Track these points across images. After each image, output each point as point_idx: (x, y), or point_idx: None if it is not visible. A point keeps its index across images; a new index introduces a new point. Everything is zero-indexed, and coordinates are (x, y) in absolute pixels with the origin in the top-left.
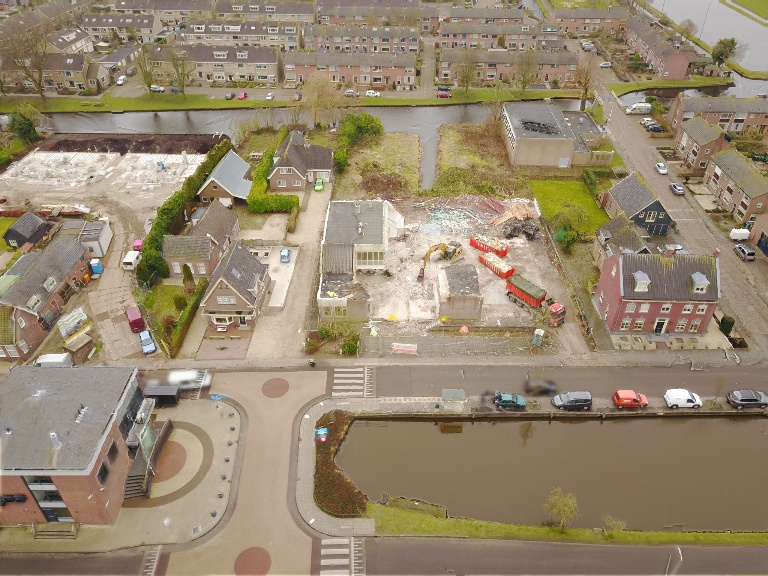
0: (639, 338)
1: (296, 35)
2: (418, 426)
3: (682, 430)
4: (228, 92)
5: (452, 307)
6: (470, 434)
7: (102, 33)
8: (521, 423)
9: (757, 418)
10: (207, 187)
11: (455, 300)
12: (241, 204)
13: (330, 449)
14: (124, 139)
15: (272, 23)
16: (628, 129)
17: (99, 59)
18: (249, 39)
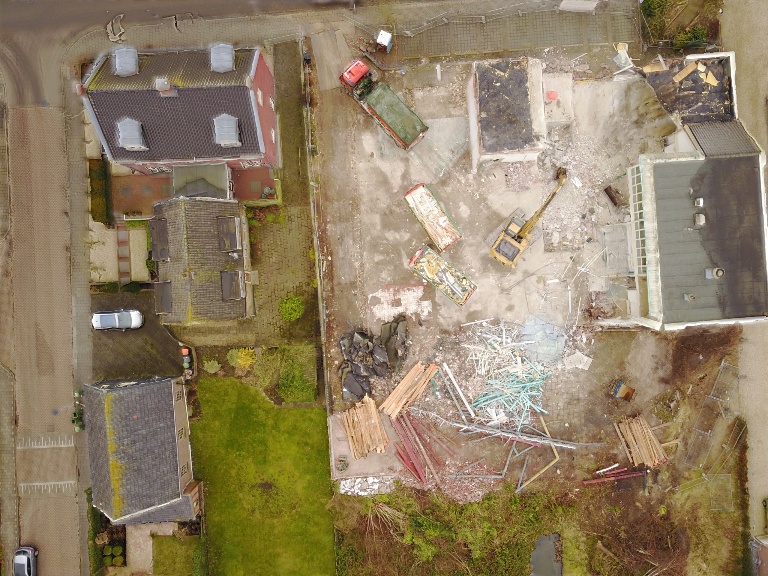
0: None
1: None
2: None
3: None
4: None
5: None
6: None
7: None
8: None
9: None
10: None
11: None
12: None
13: None
14: None
15: None
16: None
17: None
18: None
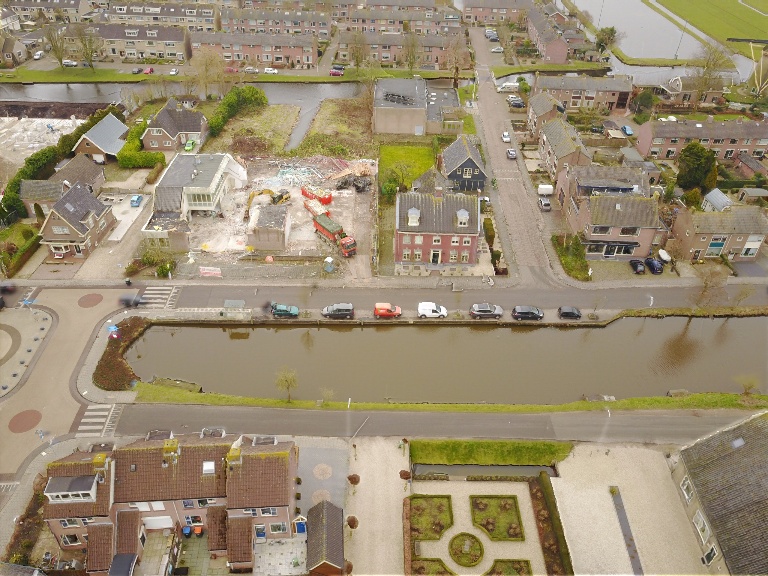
0: (418, 267)
1: (213, 17)
2: (207, 331)
3: (432, 337)
4: (136, 67)
5: (259, 239)
6: (252, 339)
7: (31, 13)
8: (301, 332)
9: (494, 327)
10: (80, 144)
11: (260, 232)
12: (114, 161)
13: (120, 344)
14: (23, 105)
15: (190, 6)
16: (494, 105)
17: (21, 36)
18: (169, 20)
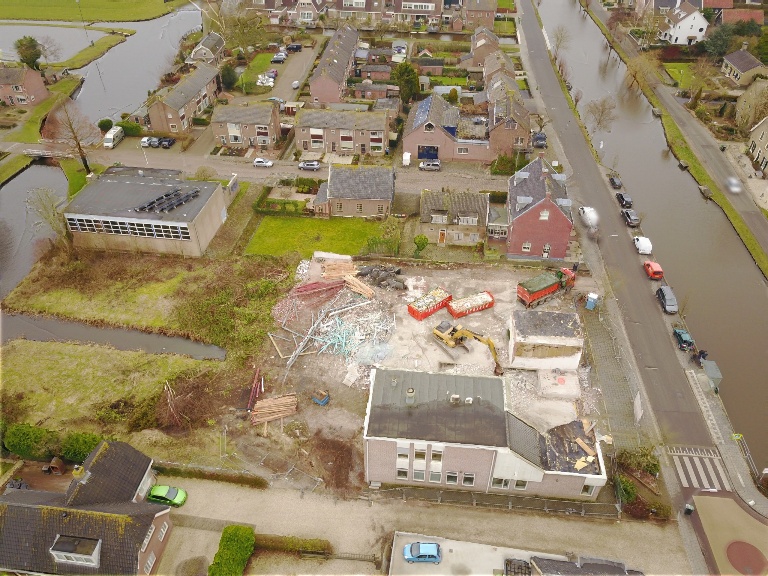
0: None
1: None
2: None
3: None
4: None
5: None
6: None
7: None
8: None
9: None
10: None
11: None
12: None
13: None
14: None
15: None
16: (149, 158)
17: None
18: None
